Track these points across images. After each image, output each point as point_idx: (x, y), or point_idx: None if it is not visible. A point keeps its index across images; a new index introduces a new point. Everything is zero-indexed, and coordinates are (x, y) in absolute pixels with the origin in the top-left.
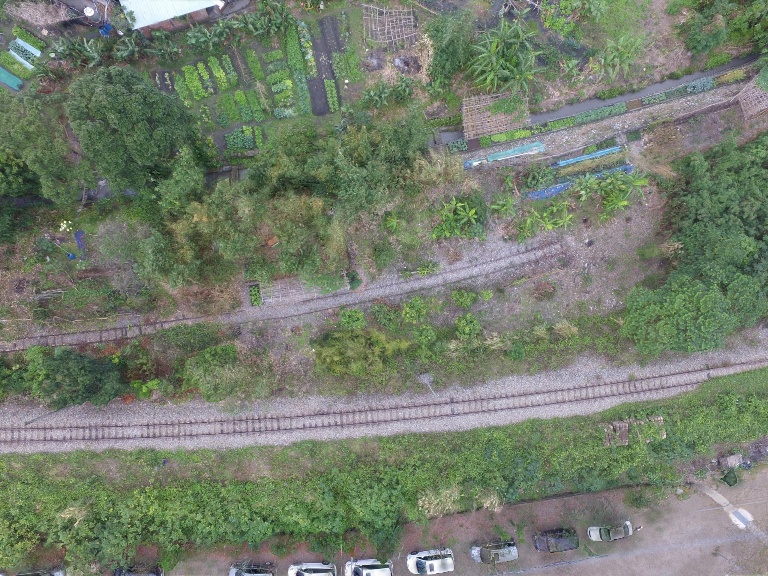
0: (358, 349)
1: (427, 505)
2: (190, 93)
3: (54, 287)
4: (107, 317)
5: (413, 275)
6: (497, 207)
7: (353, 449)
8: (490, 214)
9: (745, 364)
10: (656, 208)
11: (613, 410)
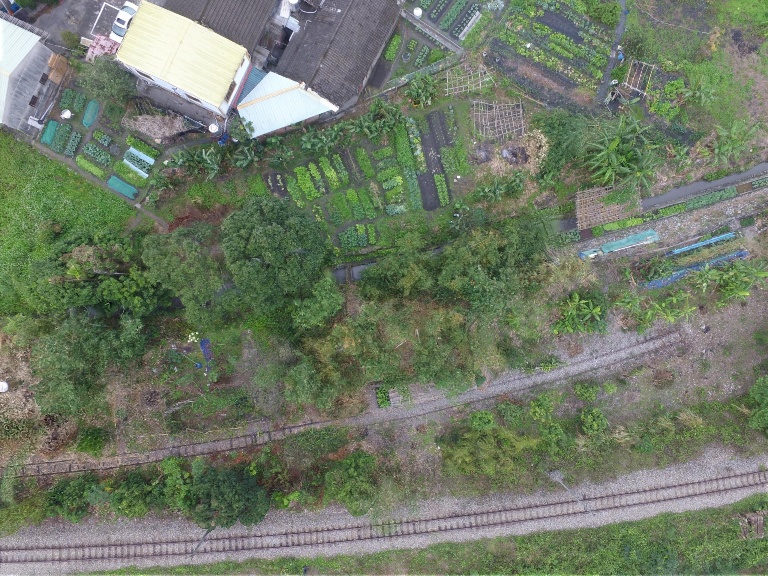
0: (490, 450)
1: None
2: (302, 194)
3: (183, 397)
4: (237, 425)
5: (535, 370)
6: (622, 304)
7: (489, 549)
8: (608, 305)
9: None
10: None
11: (744, 501)
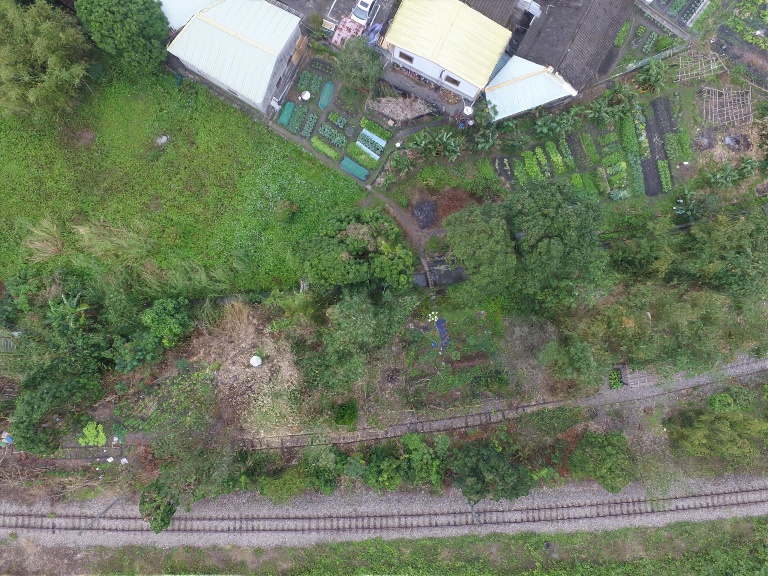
0: (728, 432)
1: None
2: (528, 178)
3: (419, 375)
4: (472, 403)
5: None
6: None
7: (725, 529)
8: None
9: None
10: None
11: None
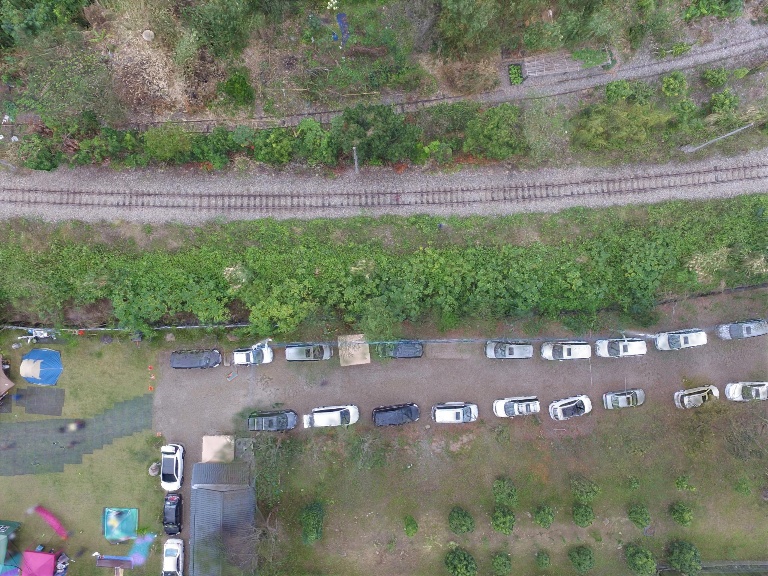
0: (624, 118)
1: (696, 267)
2: None
3: None
4: (371, 96)
5: (665, 56)
6: None
7: (620, 216)
8: None
9: None
10: None
11: None
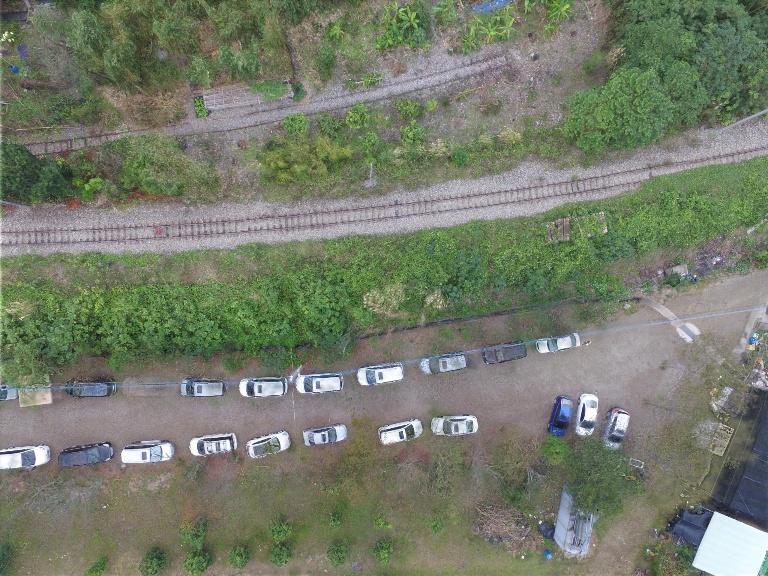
0: (302, 153)
1: (372, 303)
2: None
3: None
4: (52, 129)
5: (358, 87)
6: (438, 9)
7: (298, 252)
8: (435, 27)
9: (686, 162)
10: (601, 21)
11: (556, 210)
